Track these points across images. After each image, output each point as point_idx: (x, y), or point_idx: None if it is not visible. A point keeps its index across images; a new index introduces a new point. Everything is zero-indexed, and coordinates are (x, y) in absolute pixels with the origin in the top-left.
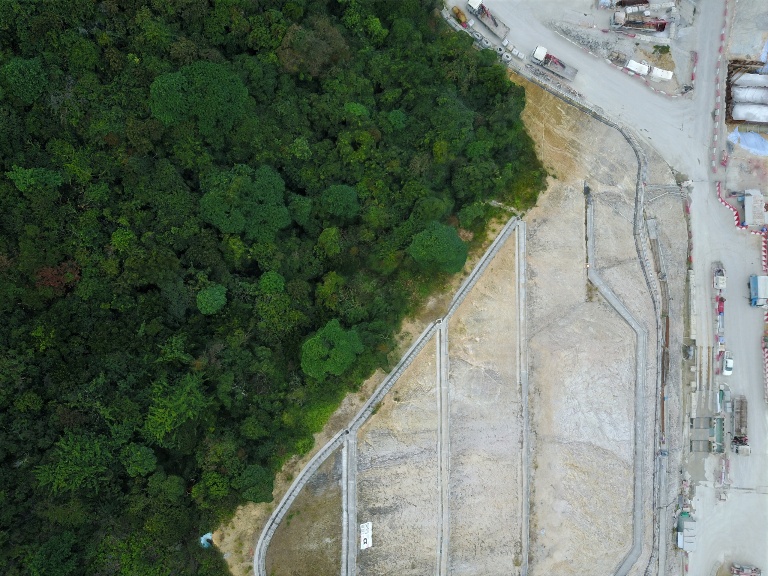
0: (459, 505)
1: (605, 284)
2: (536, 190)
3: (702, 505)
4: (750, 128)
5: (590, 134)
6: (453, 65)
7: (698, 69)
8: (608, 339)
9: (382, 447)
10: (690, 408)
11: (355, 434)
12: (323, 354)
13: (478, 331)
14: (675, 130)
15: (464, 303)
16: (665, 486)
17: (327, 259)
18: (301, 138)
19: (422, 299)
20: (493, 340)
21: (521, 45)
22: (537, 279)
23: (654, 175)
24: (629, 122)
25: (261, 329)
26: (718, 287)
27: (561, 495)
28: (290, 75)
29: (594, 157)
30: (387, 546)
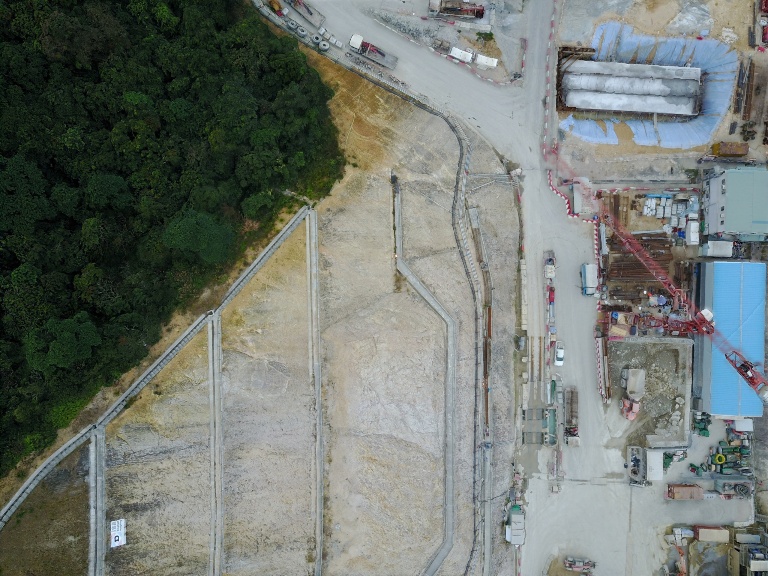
0: (236, 500)
1: (413, 274)
2: (331, 179)
3: (535, 498)
4: (587, 116)
5: (409, 123)
6: (240, 52)
7: (528, 56)
8: (410, 329)
9: (139, 442)
10: (522, 399)
11: (102, 429)
12: (38, 346)
13: (260, 322)
14: (505, 118)
15: (241, 294)
16: (490, 479)
17: (91, 250)
18: (75, 128)
19: (194, 290)
20: (279, 332)
21: (340, 33)
22: (332, 269)
23: (479, 164)
24: (456, 110)
25: (7, 322)
26: (547, 276)
27: (357, 489)
28: (62, 64)
29: (409, 146)
30: (145, 543)
